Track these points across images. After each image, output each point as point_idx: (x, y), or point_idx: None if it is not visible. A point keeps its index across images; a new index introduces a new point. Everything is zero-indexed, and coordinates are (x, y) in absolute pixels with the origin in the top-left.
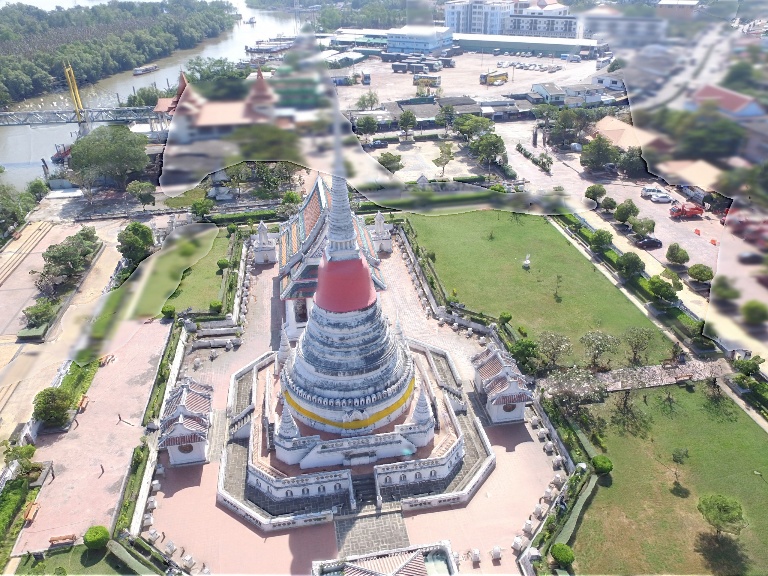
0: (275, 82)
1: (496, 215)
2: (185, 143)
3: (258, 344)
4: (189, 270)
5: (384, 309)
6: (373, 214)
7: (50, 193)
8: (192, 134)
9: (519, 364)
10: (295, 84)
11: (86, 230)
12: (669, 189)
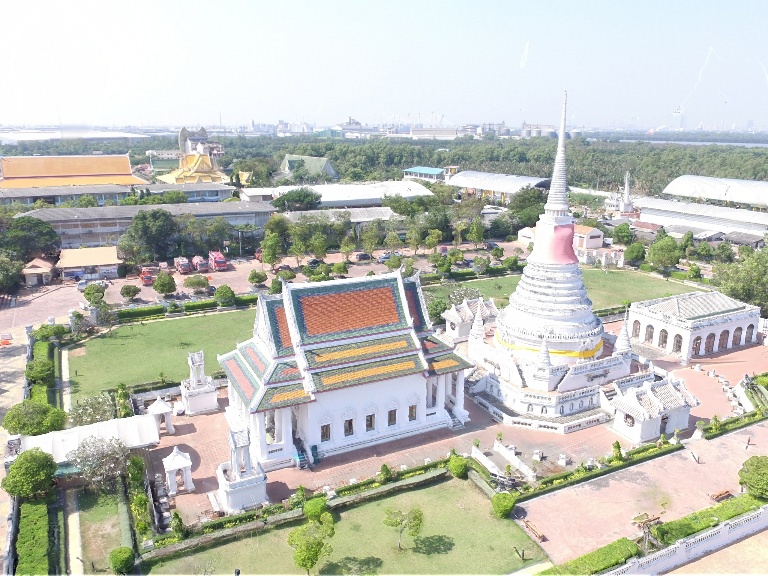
0: (724, 63)
1: (108, 345)
2: (764, 79)
3: (490, 437)
4: (333, 566)
5: None
6: None
7: None
8: (760, 76)
9: (436, 323)
10: (715, 65)
11: None
12: (70, 283)
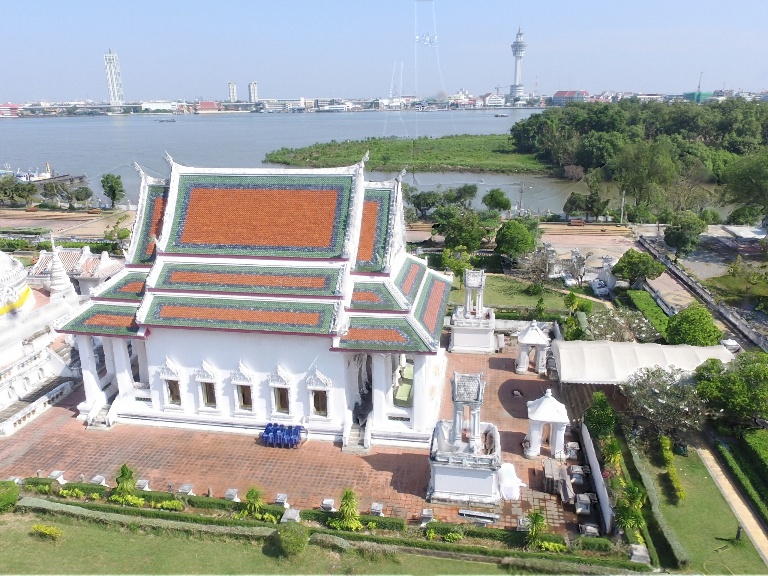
0: None
1: None
2: None
3: None
4: None
5: (151, 430)
6: (736, 497)
7: (744, 226)
8: None
9: None
10: None
11: (525, 218)
12: None
